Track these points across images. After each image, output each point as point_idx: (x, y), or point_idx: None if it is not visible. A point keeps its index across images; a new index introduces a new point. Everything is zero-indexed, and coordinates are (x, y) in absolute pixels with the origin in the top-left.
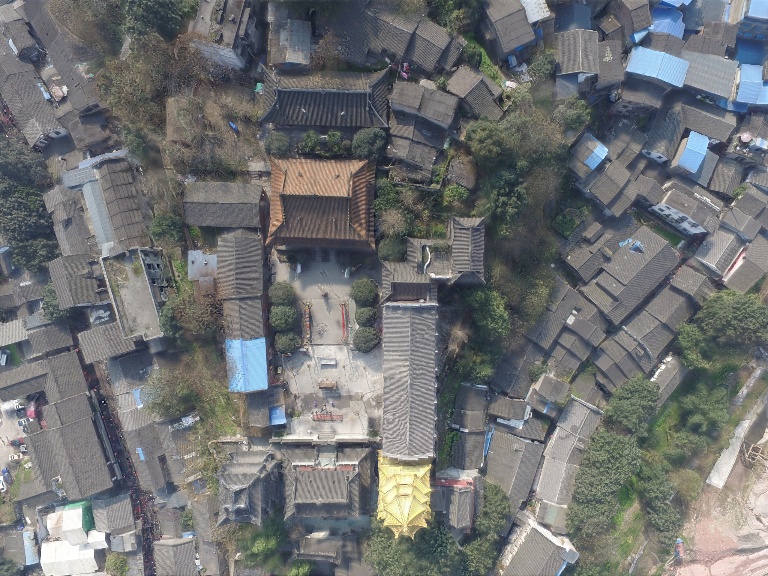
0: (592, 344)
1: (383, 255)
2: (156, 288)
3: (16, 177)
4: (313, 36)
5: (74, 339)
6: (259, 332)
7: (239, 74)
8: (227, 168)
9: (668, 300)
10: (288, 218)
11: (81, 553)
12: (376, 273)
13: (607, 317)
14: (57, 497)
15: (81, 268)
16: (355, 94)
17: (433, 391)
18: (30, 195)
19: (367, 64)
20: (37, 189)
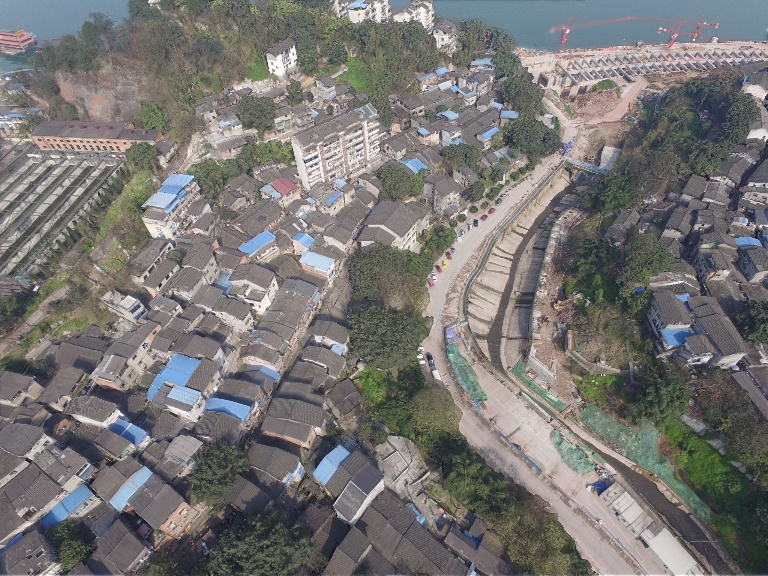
0: None
1: None
2: None
3: None
4: None
5: None
6: None
7: None
8: None
9: None
10: None
11: None
12: None
13: None
14: None
15: None
16: None
17: None
18: None
19: None
20: None
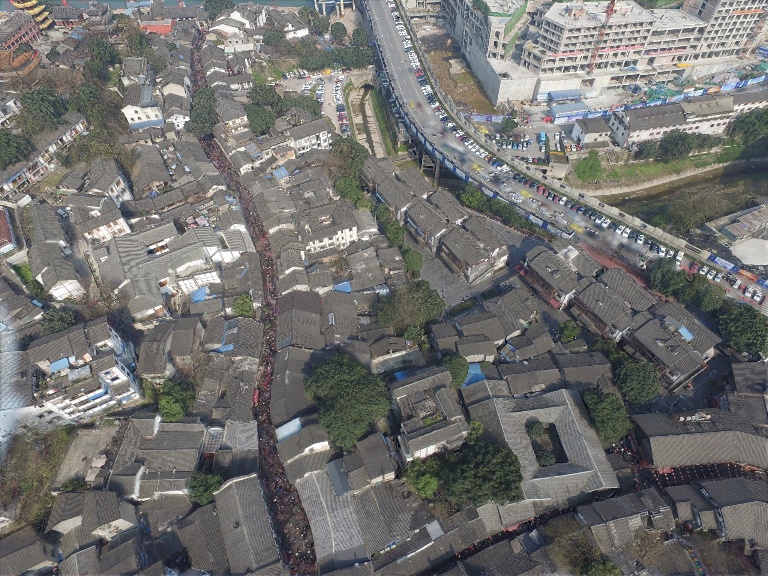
0: None
1: None
2: None
3: None
4: None
5: None
6: None
7: None
8: None
9: None
10: None
11: (235, 47)
12: None
13: None
14: None
15: None
16: None
17: None
18: None
19: None
20: None
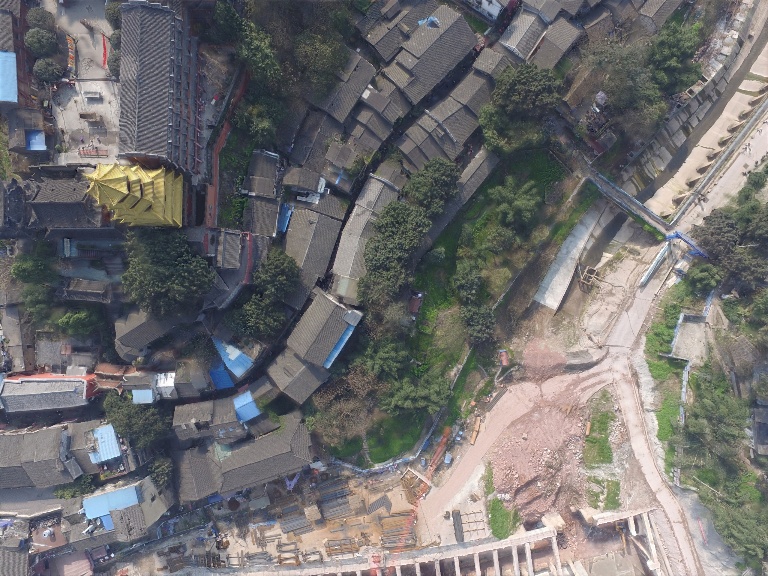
0: (388, 120)
1: None
2: None
3: None
4: None
5: None
6: (8, 46)
7: None
8: None
9: (471, 84)
10: None
11: None
12: None
13: (409, 99)
14: None
15: None
16: None
17: (167, 95)
18: None
19: None
20: None
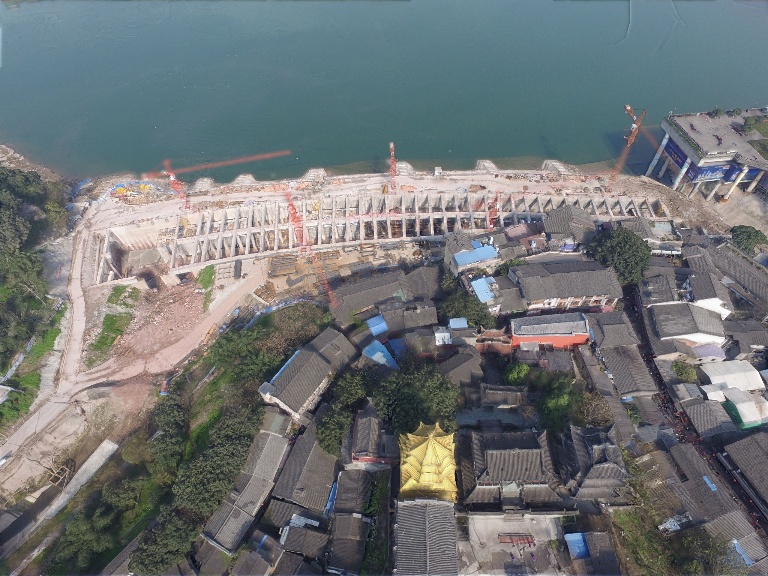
0: None
1: None
2: None
3: None
4: None
5: None
6: None
7: None
8: None
9: None
10: None
11: (723, 380)
12: None
13: None
14: None
15: None
16: None
17: None
18: None
19: None
20: None
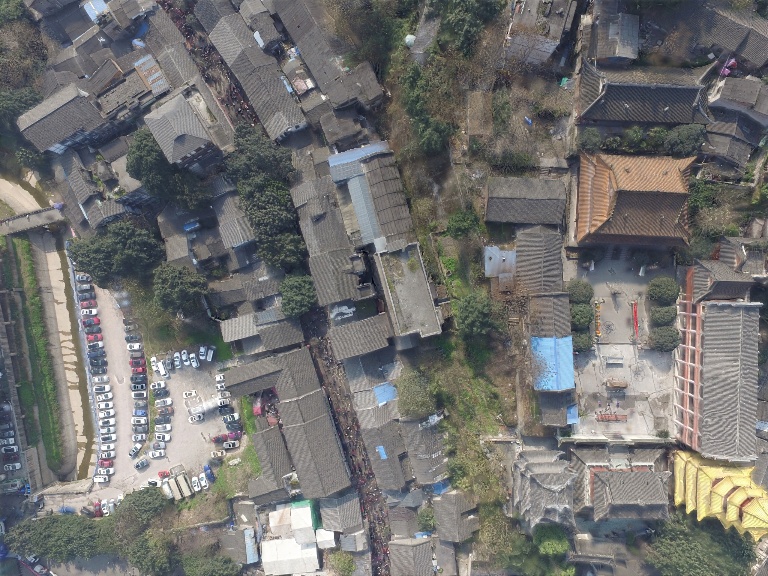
0: None
1: (697, 253)
2: (432, 284)
3: (268, 171)
4: (640, 30)
5: (305, 335)
6: (568, 330)
7: (540, 68)
8: (519, 163)
9: None
10: (614, 214)
11: (303, 552)
12: (667, 271)
13: None
14: (285, 495)
15: (344, 263)
16: (686, 89)
17: None
18: (279, 189)
19: (687, 59)
20: (282, 183)
